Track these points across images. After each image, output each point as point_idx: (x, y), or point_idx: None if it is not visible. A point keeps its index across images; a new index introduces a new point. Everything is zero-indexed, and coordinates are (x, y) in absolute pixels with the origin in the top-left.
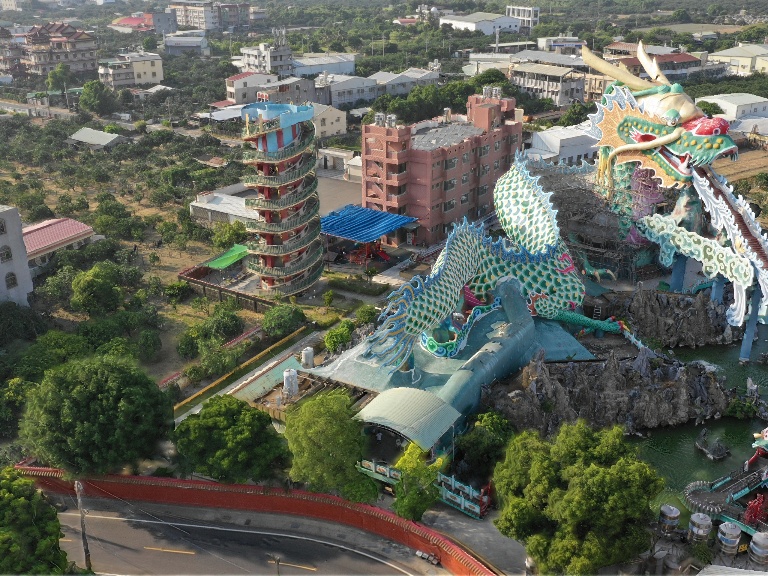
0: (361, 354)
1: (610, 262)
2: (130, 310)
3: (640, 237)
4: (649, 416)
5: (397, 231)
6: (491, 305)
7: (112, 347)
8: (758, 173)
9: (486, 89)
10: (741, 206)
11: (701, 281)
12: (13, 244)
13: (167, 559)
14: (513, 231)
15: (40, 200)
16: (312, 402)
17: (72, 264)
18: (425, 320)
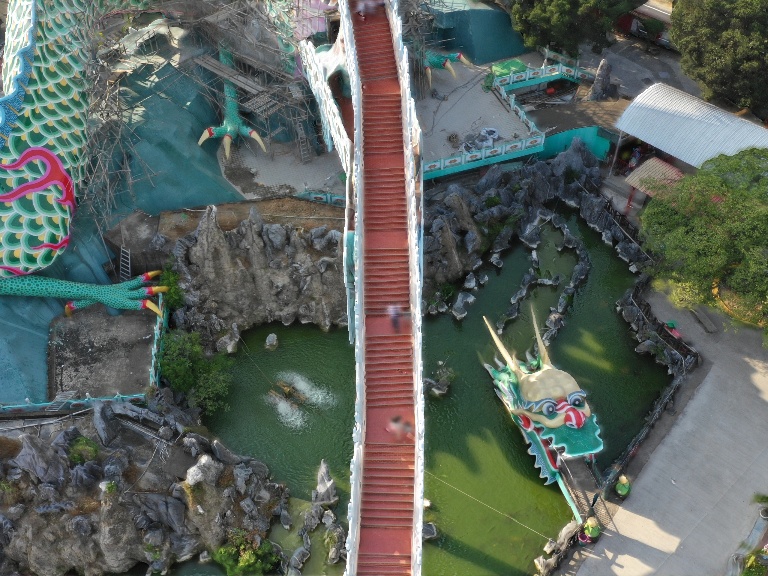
0: None
1: (255, 118)
2: None
3: (301, 78)
4: (34, 565)
5: None
6: None
7: None
8: None
9: None
10: (402, 75)
11: (428, 166)
12: None
13: None
14: None
15: None
16: None
17: None
18: None
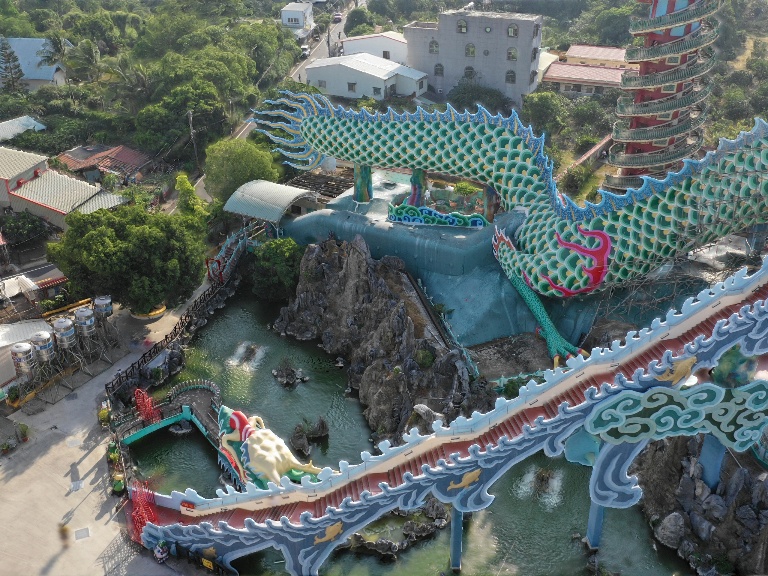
0: (382, 180)
1: None
2: (538, 135)
3: None
4: None
5: None
6: None
7: None
8: None
9: None
10: None
11: None
12: (521, 49)
13: None
14: None
15: None
16: None
17: (604, 100)
18: None
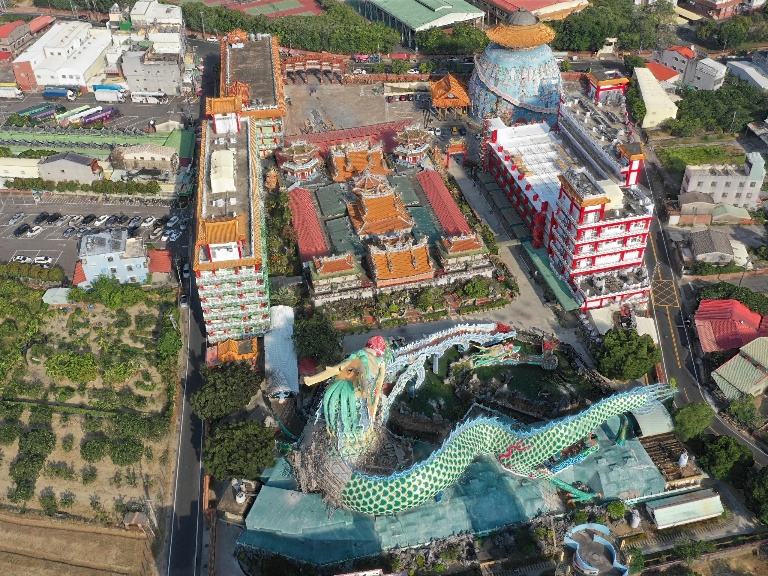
0: None
1: None
2: None
3: None
4: None
5: None
6: None
7: None
8: None
9: None
10: None
11: None
12: None
13: (760, 459)
14: None
15: None
16: (700, 411)
17: None
18: None
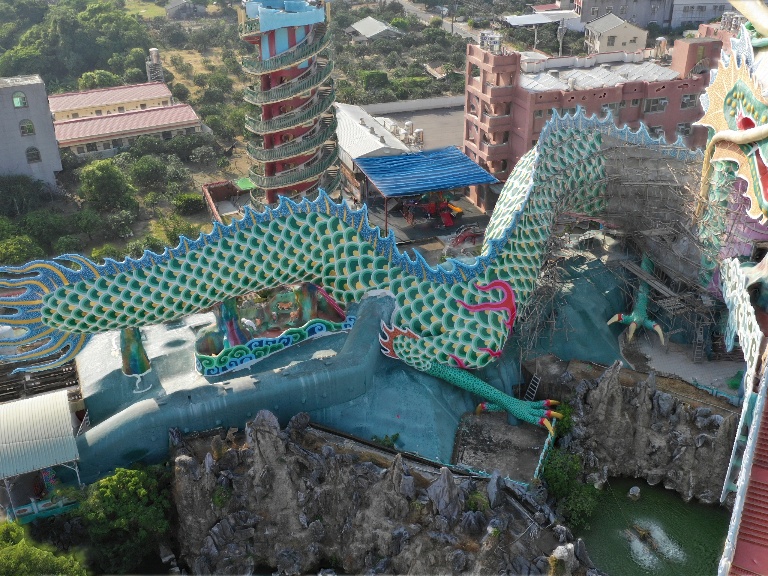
0: None
1: None
2: None
3: (716, 289)
4: None
5: (486, 192)
6: (342, 323)
7: (4, 244)
8: None
9: (725, 16)
10: None
11: None
12: (37, 119)
13: None
14: None
15: (227, 83)
16: None
17: (141, 152)
18: (81, 317)
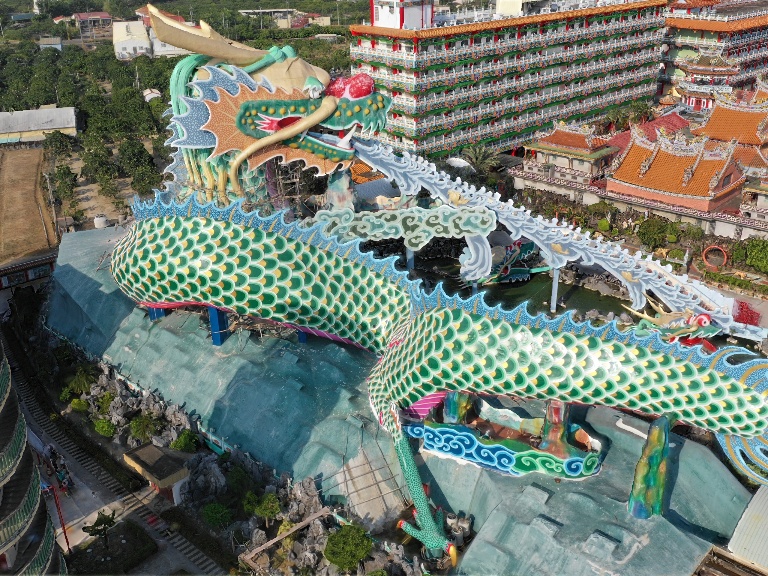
0: (615, 548)
1: None
2: None
3: None
4: None
5: None
6: None
7: None
8: (19, 176)
9: None
10: None
11: None
12: None
13: None
14: (301, 301)
15: None
16: None
17: None
18: None
